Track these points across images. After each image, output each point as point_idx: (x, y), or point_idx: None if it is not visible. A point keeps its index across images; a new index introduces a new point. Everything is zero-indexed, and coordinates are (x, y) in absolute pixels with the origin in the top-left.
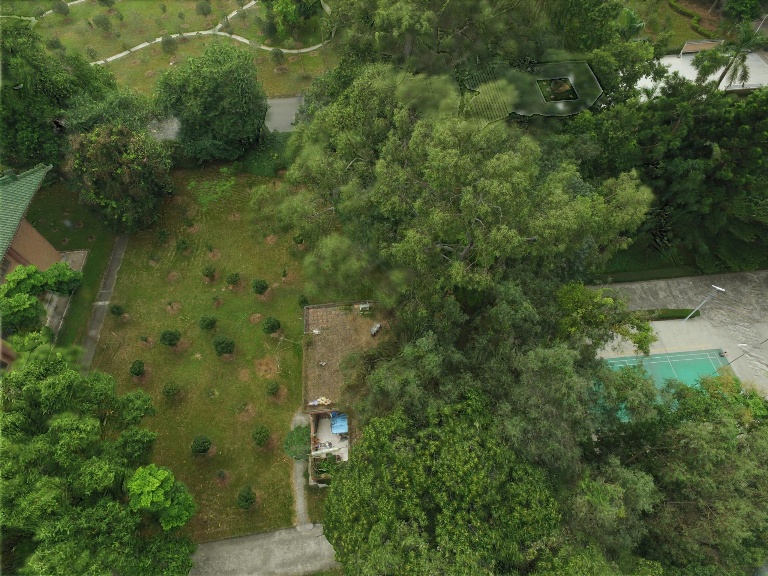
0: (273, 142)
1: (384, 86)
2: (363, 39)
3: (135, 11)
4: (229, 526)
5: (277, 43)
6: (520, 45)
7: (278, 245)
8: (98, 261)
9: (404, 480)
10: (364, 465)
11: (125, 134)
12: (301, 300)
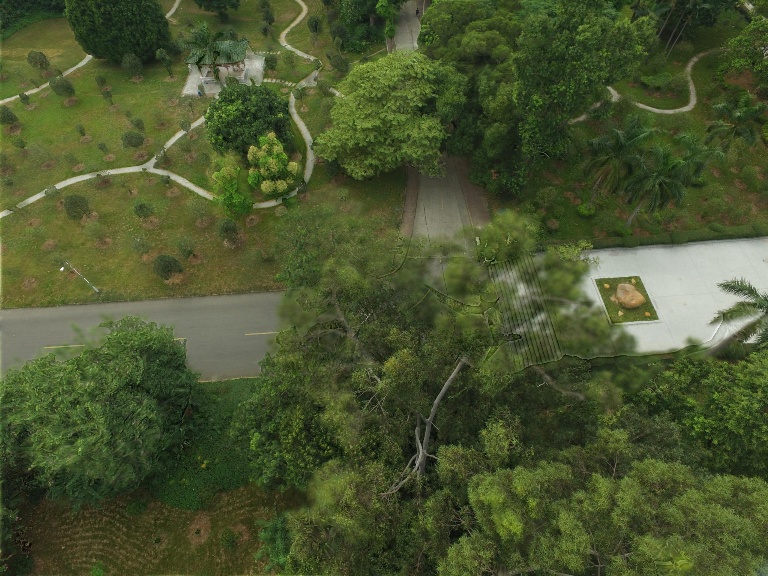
0: (204, 429)
1: (374, 542)
2: (338, 368)
3: (45, 131)
4: None
5: None
6: (566, 210)
7: None
8: None
9: None
10: None
11: None
12: None
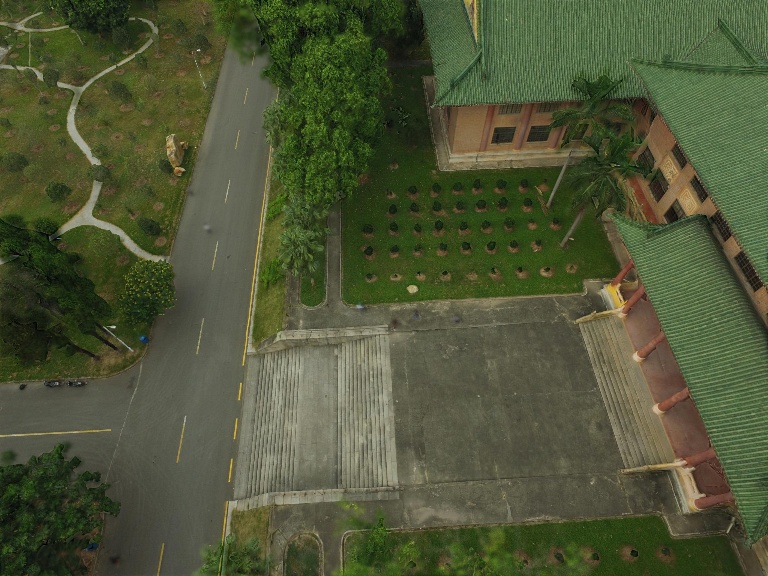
0: None
1: None
2: None
3: None
4: None
5: (133, 46)
6: None
7: None
8: None
9: None
10: None
11: None
12: None
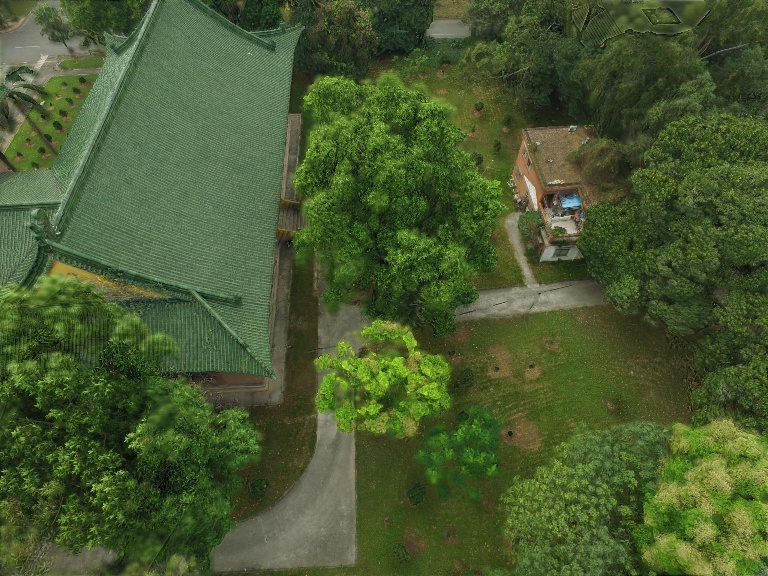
0: (433, 43)
1: None
2: None
3: None
4: (476, 283)
5: None
6: None
7: (458, 113)
8: (312, 121)
9: (709, 144)
10: (662, 155)
11: (355, 8)
12: (498, 142)
